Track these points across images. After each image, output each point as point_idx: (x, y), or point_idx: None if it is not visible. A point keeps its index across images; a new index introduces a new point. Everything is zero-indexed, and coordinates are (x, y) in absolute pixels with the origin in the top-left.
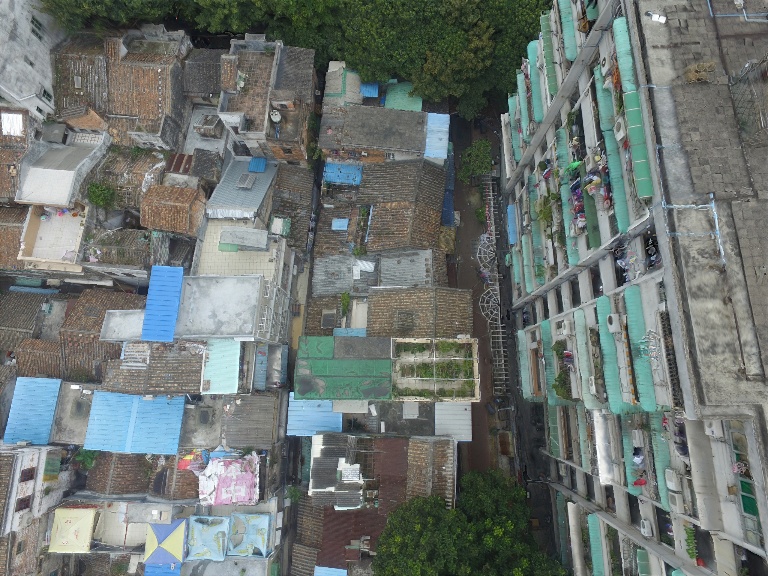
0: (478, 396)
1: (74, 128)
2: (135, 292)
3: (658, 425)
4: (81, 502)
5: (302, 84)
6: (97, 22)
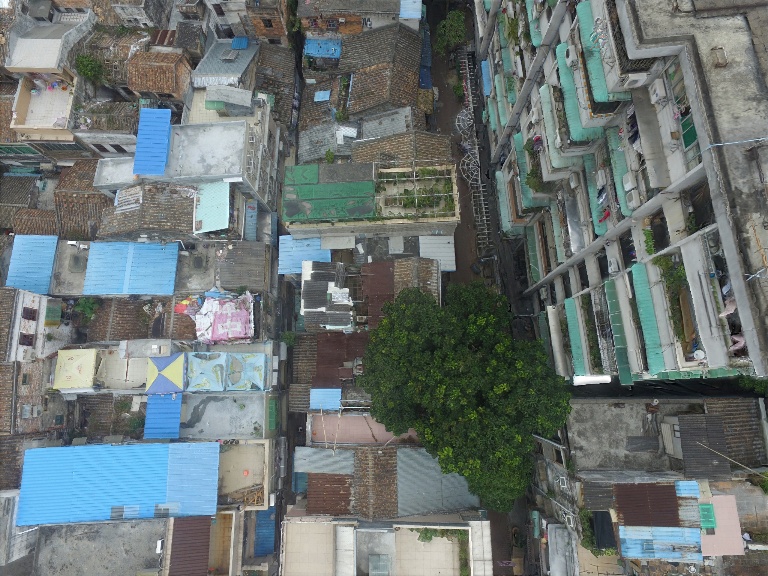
0: (458, 215)
1: (59, 7)
2: None
3: (615, 144)
4: (83, 348)
5: None
6: None
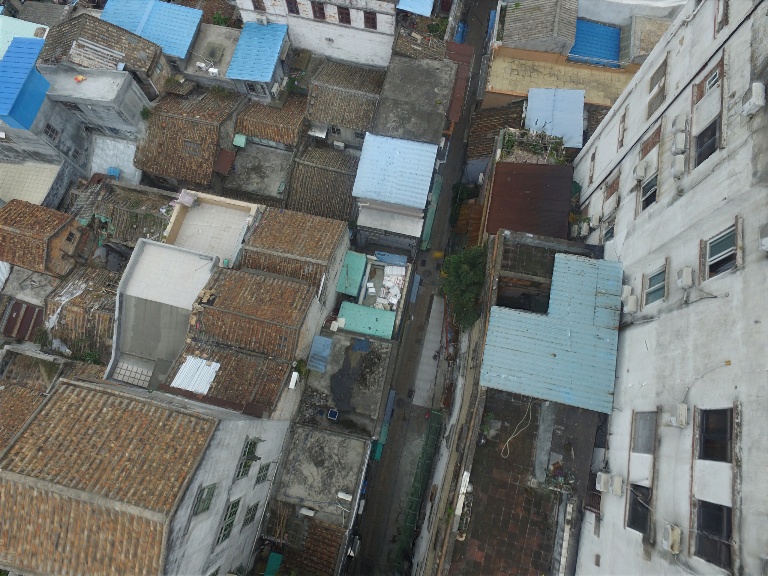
0: None
1: None
2: None
3: None
4: None
5: None
6: None
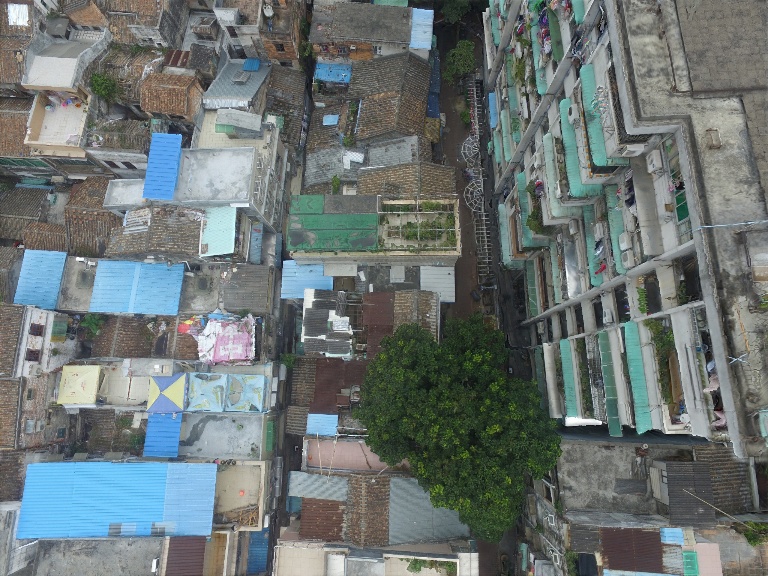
0: (459, 250)
1: (76, 25)
2: None
3: (613, 202)
4: (87, 364)
5: None
6: None
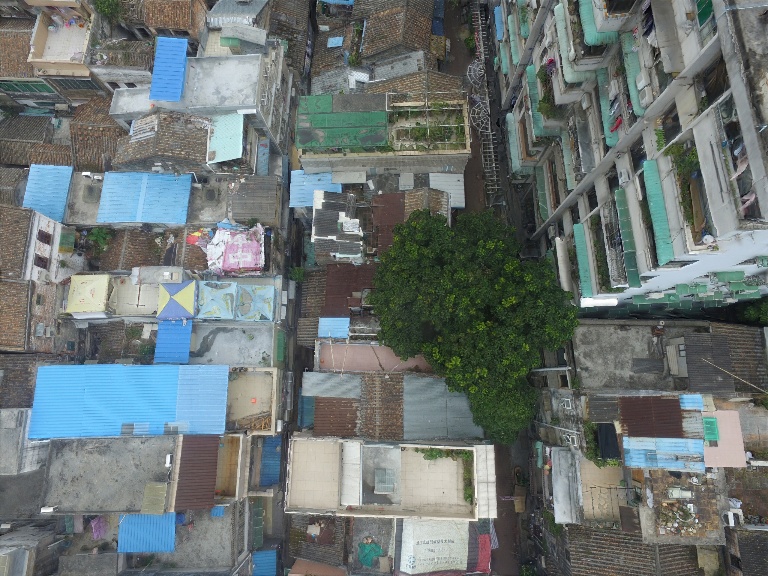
0: (469, 148)
1: None
2: None
3: (629, 47)
4: None
5: None
6: None
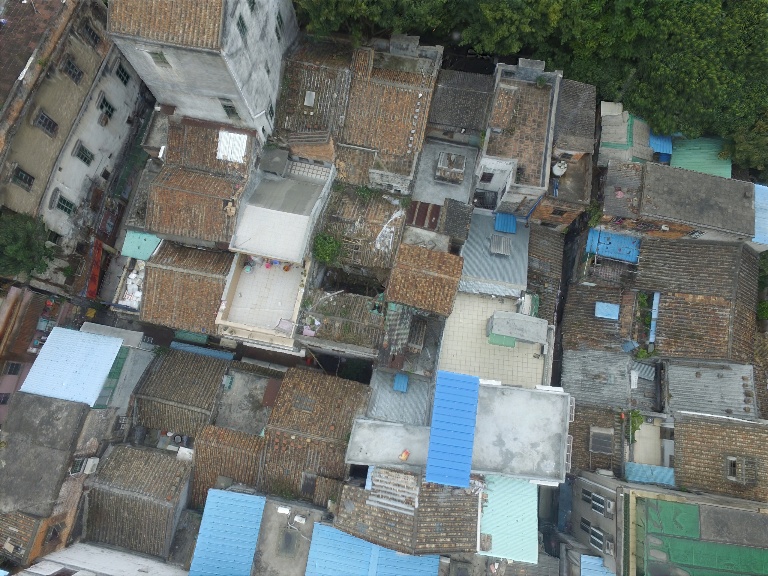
0: None
1: (292, 155)
2: (316, 361)
3: None
4: None
5: (582, 129)
6: (359, 26)
